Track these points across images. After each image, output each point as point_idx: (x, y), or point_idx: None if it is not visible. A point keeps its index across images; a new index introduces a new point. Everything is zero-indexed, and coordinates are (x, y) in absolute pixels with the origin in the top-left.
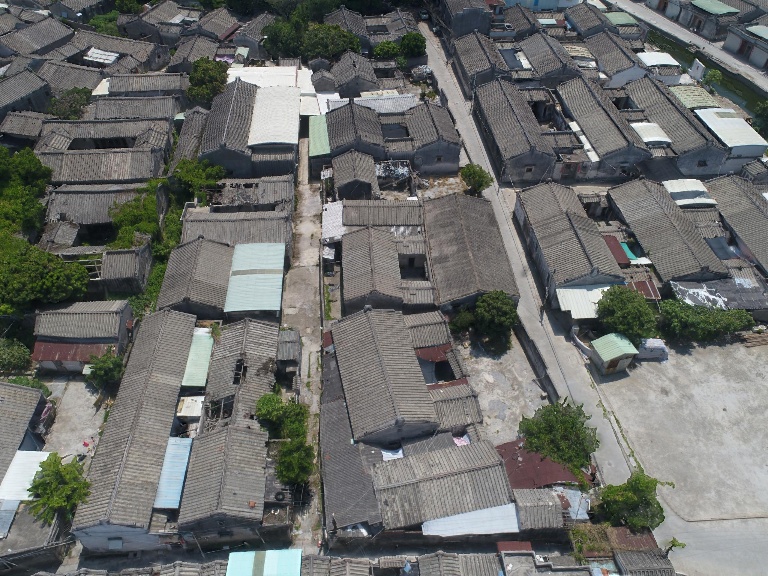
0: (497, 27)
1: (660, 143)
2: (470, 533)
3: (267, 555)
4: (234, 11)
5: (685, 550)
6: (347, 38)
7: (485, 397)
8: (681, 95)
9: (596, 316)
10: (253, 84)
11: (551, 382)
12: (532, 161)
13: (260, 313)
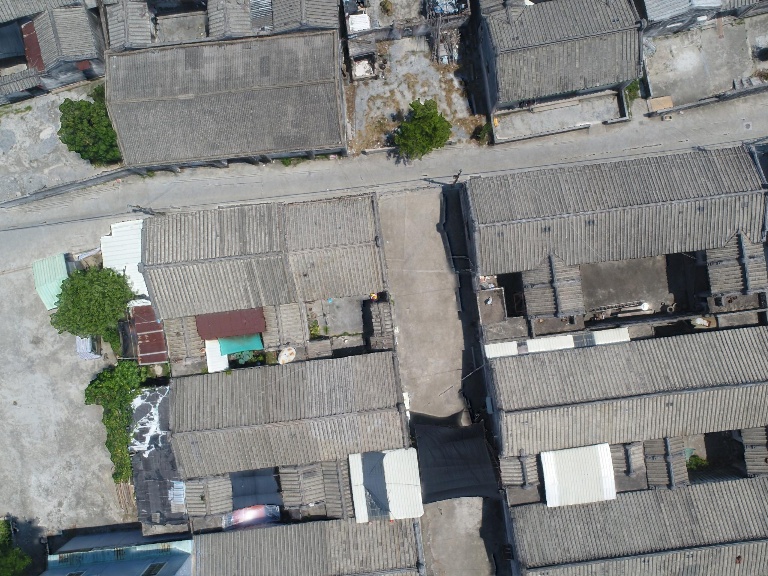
0: None
1: None
2: None
3: None
4: None
5: None
6: None
7: (18, 127)
8: None
9: None
10: None
11: None
12: None
13: None
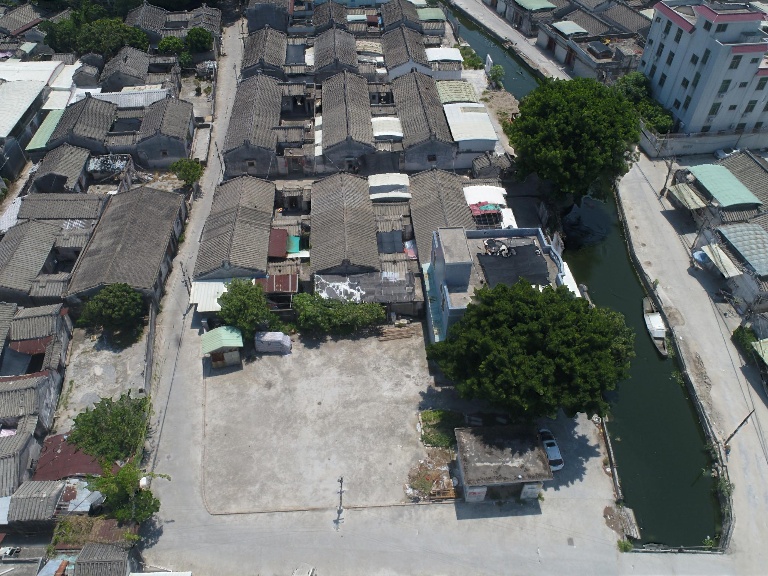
0: (300, 23)
1: (392, 137)
2: None
3: None
4: (39, 7)
5: (192, 543)
6: (129, 33)
7: (83, 390)
8: (443, 90)
9: None
10: (1, 78)
11: None
12: (251, 155)
13: None
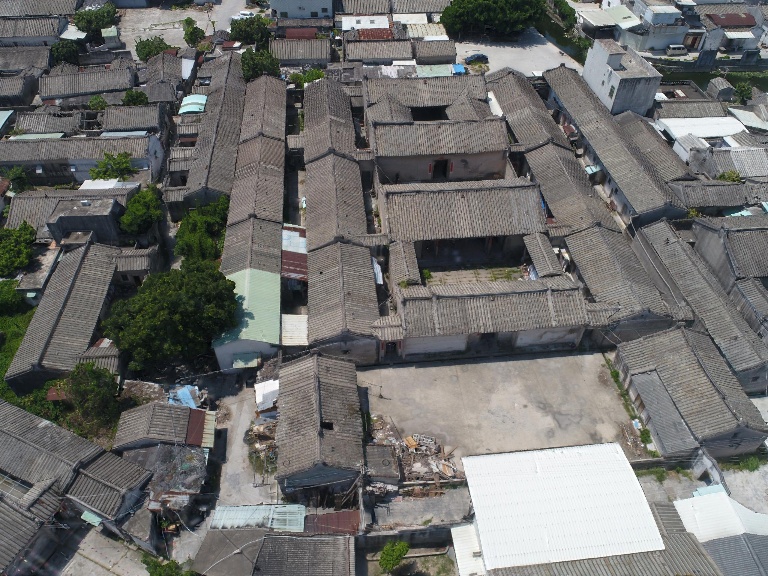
0: None
1: None
2: (191, 70)
3: (183, 104)
4: None
5: None
6: None
7: None
8: None
9: (86, 33)
10: None
11: (120, 52)
12: None
13: (8, 122)
